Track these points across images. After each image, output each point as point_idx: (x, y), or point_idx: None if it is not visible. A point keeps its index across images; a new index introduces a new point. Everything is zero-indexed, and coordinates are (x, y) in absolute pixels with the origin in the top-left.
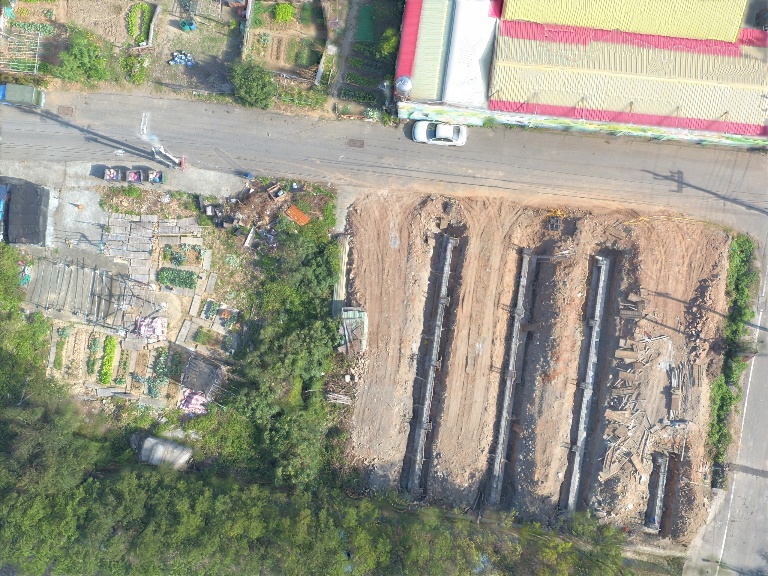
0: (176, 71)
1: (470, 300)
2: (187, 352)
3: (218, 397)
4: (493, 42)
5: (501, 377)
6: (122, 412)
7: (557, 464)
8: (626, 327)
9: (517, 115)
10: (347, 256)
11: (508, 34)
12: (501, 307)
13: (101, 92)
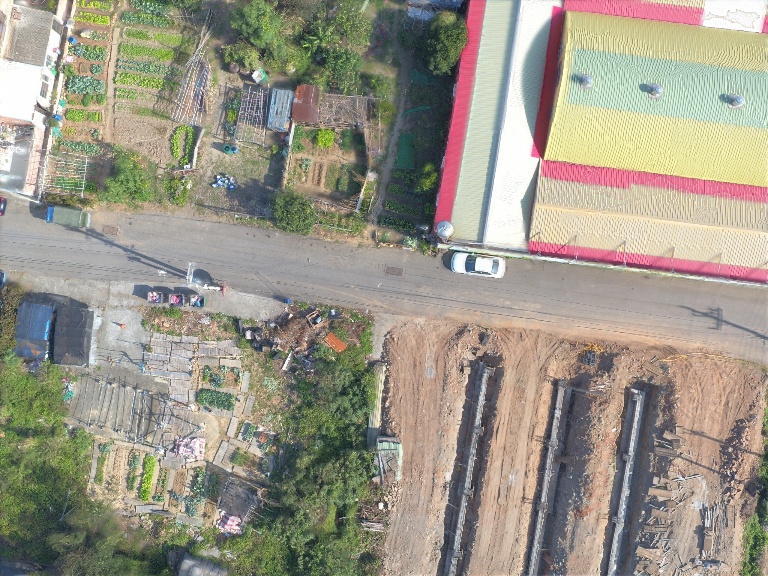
0: (219, 194)
1: (504, 431)
2: (224, 473)
3: None
4: (536, 182)
5: (533, 507)
6: (160, 530)
7: None
8: (660, 464)
9: (558, 256)
10: (383, 384)
11: (551, 175)
12: (535, 439)
13: (145, 213)
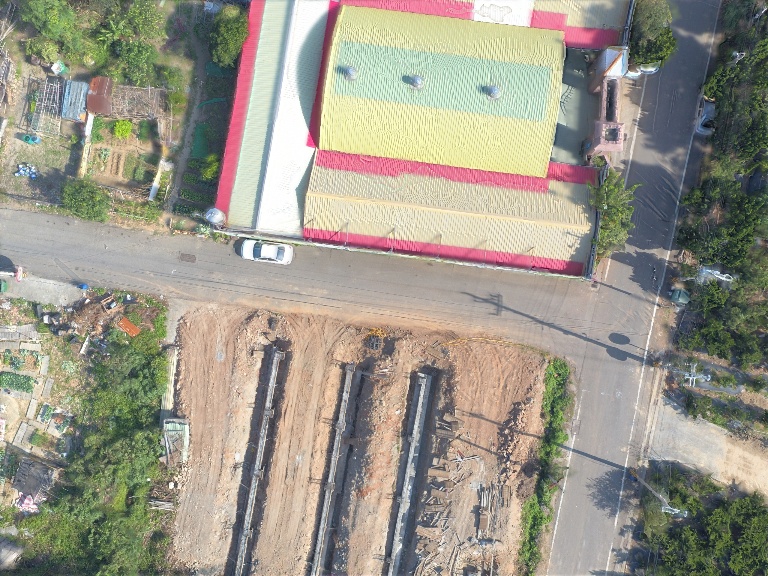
0: (21, 183)
1: (292, 413)
2: (23, 453)
3: (50, 497)
4: (310, 171)
5: (321, 488)
6: None
7: (369, 575)
8: (441, 445)
9: (331, 243)
10: (176, 367)
11: (325, 164)
12: (322, 421)
13: None
